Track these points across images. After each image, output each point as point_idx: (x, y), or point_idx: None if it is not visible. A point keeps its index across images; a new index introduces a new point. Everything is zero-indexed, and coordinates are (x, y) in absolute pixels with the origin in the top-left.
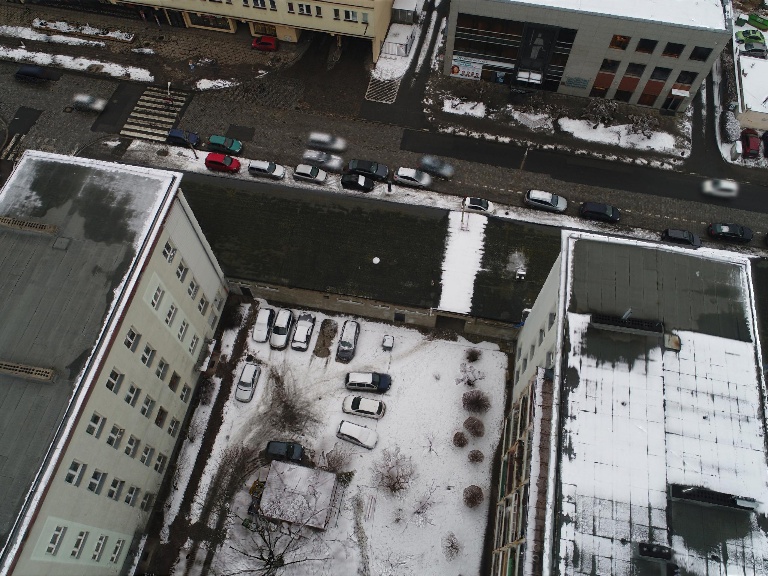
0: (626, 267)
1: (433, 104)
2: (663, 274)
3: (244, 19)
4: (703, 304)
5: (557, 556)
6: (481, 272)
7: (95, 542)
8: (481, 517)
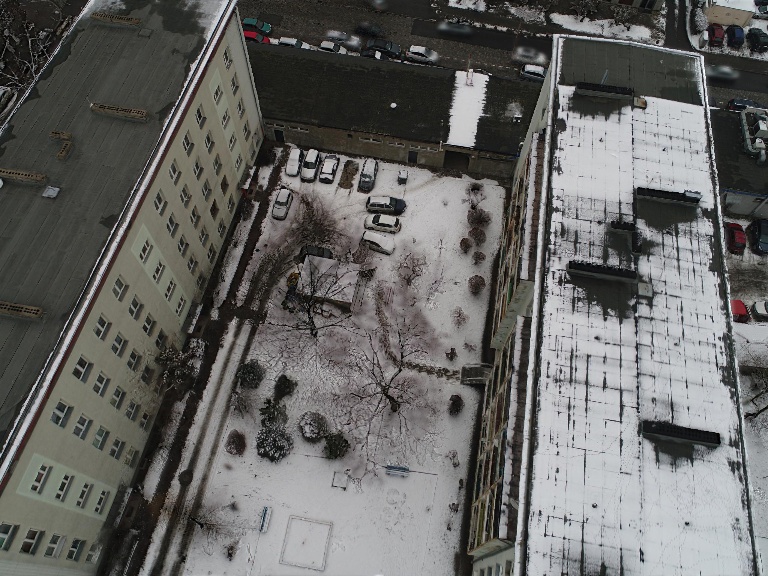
0: (604, 56)
1: (440, 0)
2: (634, 61)
3: None
4: (665, 81)
5: (548, 231)
6: (483, 117)
7: (168, 281)
8: (483, 304)
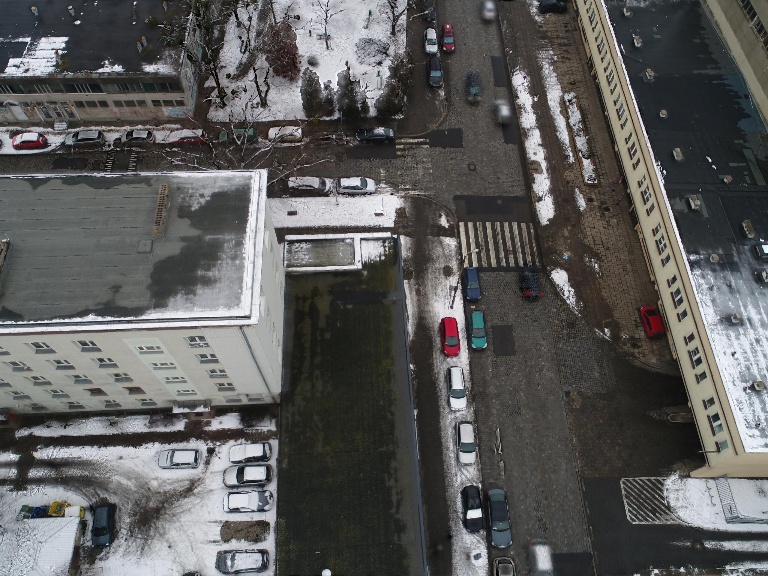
0: None
1: None
2: None
3: (658, 287)
4: None
5: None
6: None
7: None
8: None
